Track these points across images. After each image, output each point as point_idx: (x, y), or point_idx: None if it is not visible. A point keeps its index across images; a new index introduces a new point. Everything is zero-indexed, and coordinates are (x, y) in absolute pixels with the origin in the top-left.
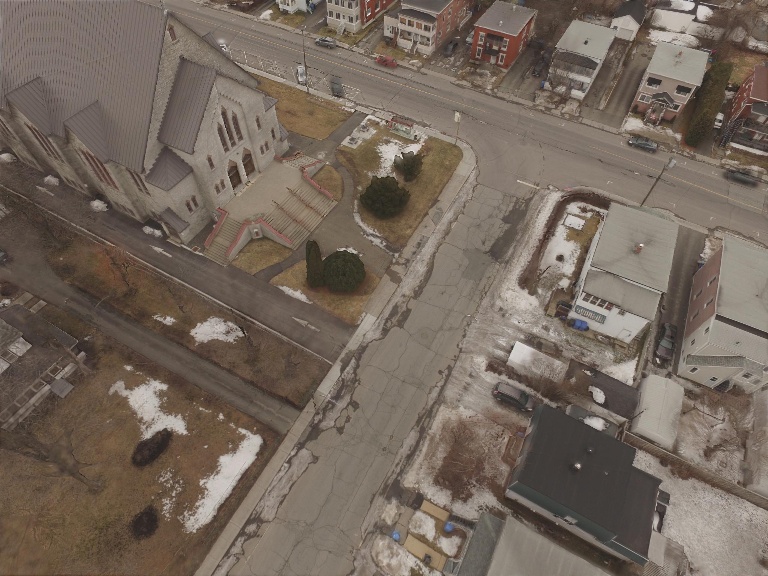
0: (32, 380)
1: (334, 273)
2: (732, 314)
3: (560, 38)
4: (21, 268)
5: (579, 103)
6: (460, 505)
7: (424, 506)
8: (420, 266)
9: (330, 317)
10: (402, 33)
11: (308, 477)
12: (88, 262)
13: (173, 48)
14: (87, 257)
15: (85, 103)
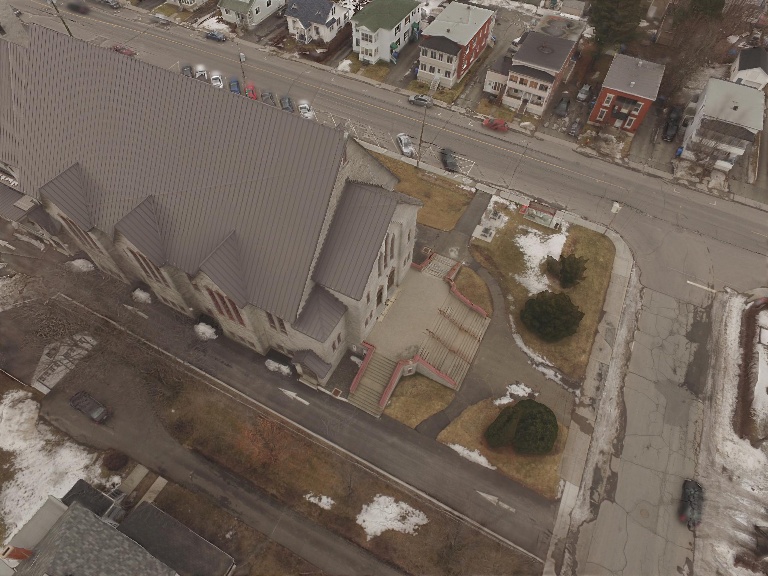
0: None
1: (531, 438)
2: None
3: (679, 92)
4: (125, 426)
5: (725, 175)
6: None
7: None
8: (610, 407)
9: (523, 489)
10: (508, 90)
11: None
12: (207, 415)
13: (342, 172)
14: (204, 407)
15: (216, 233)
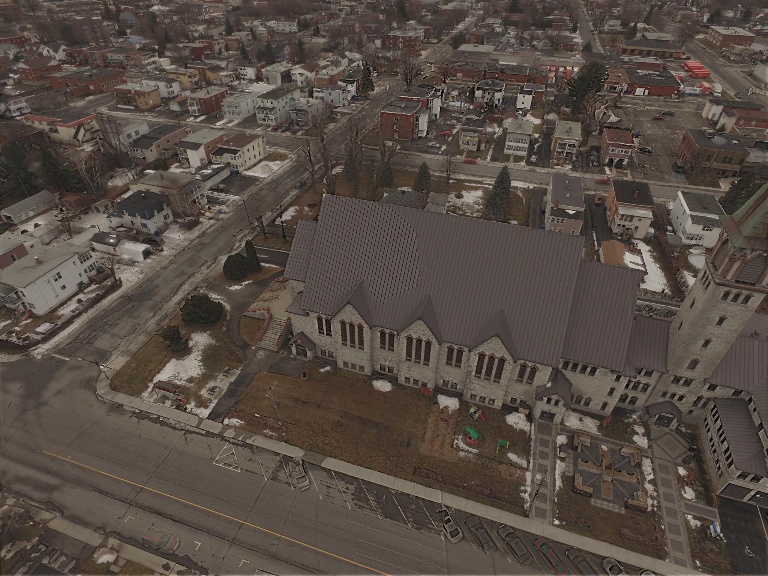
0: None
1: None
2: None
3: None
4: None
5: None
6: None
7: (208, 218)
8: (187, 288)
9: None
10: None
11: None
12: None
13: None
14: None
15: None
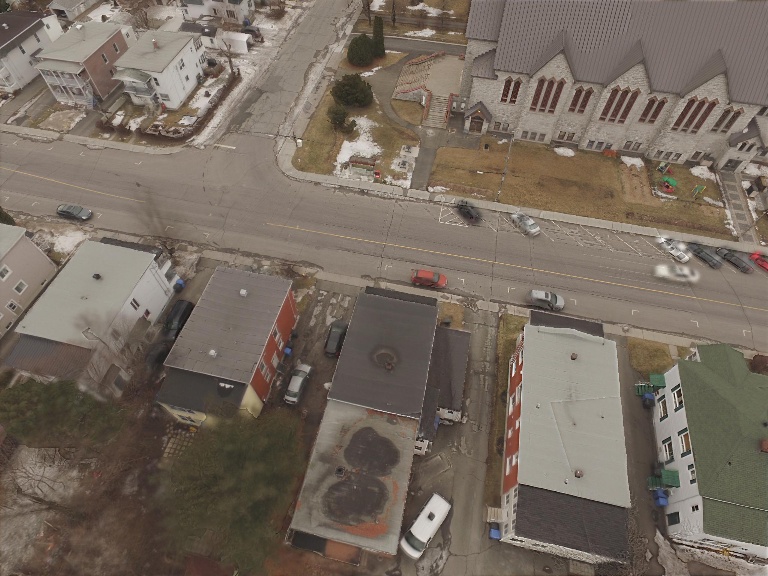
0: None
1: None
2: (111, 28)
3: None
4: None
5: None
6: (275, 8)
7: (291, 6)
8: (314, 77)
9: None
10: None
11: (344, 7)
12: None
13: None
14: None
15: None
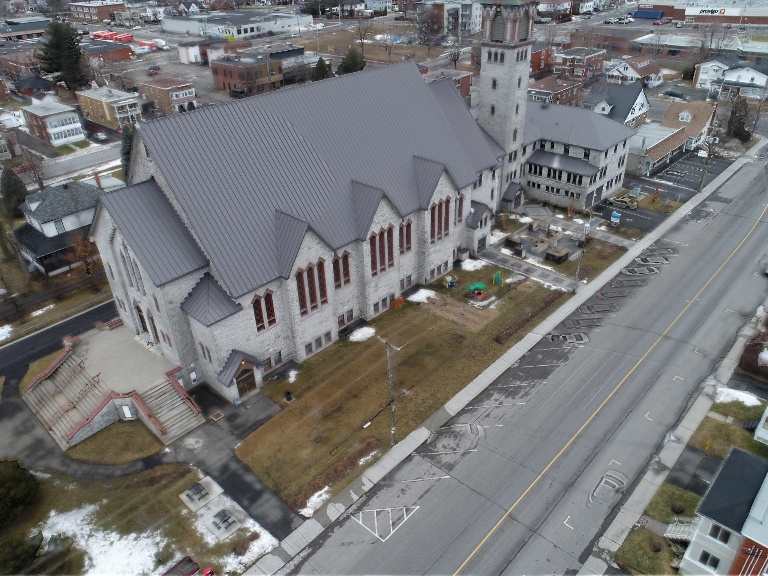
0: (25, 244)
1: None
2: None
3: None
4: None
5: None
6: None
7: None
8: None
9: None
10: None
11: None
12: None
13: None
14: None
15: None
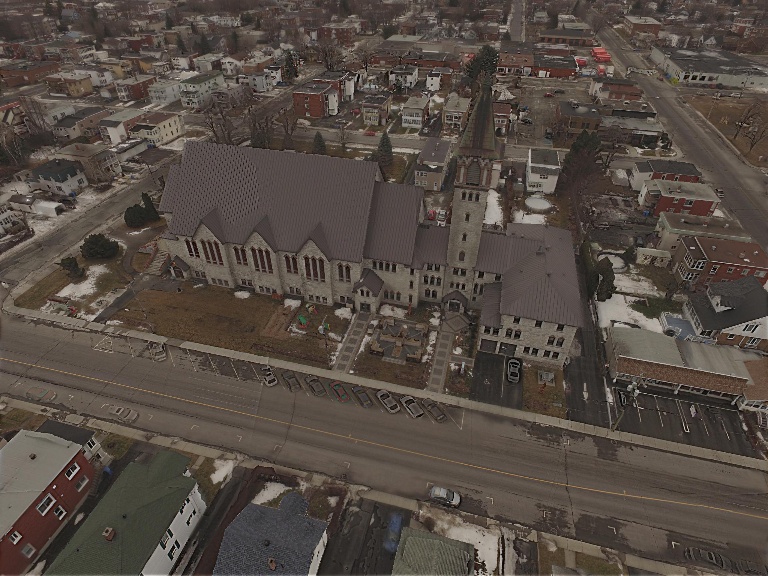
0: None
1: None
2: None
3: None
4: None
5: None
6: None
7: (121, 183)
8: None
9: None
10: None
11: None
12: None
13: None
14: None
15: None
